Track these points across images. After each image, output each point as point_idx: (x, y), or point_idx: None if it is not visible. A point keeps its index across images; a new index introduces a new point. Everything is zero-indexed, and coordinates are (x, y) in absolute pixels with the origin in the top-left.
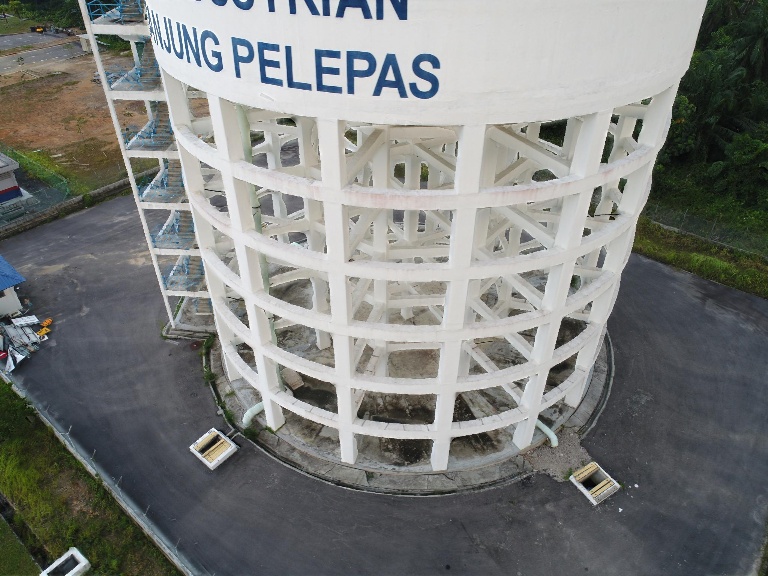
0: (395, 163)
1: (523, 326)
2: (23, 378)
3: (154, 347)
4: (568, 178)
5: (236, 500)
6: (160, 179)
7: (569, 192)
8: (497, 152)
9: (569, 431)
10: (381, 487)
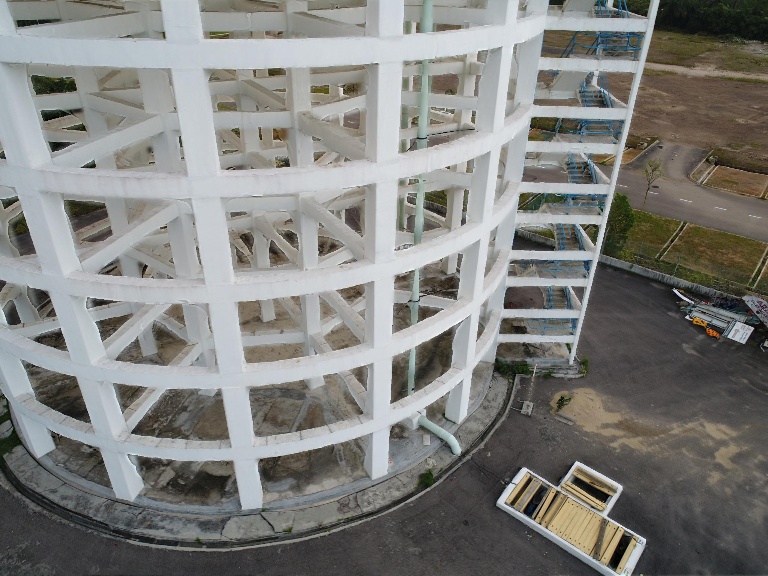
0: None
1: None
2: (656, 287)
3: None
4: None
5: None
6: (601, 182)
7: None
8: None
9: None
10: None
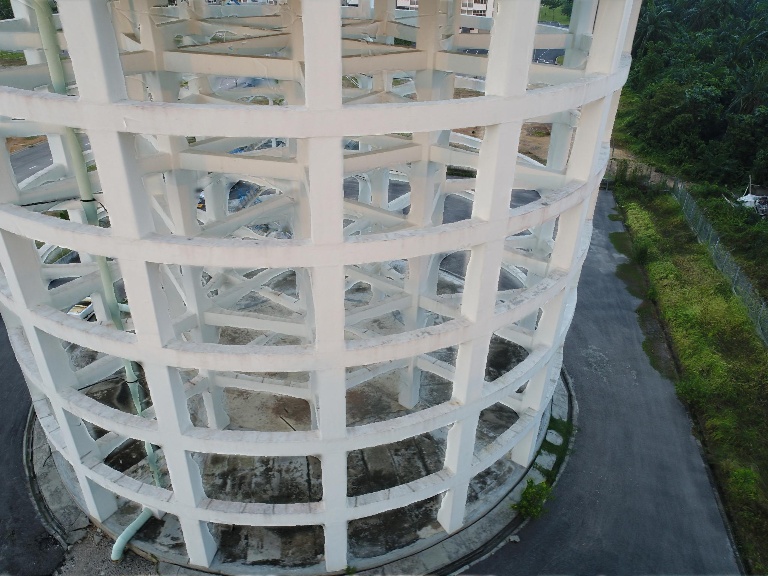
0: None
1: None
2: None
3: None
4: None
5: None
6: None
7: None
8: (160, 96)
9: (151, 572)
10: None
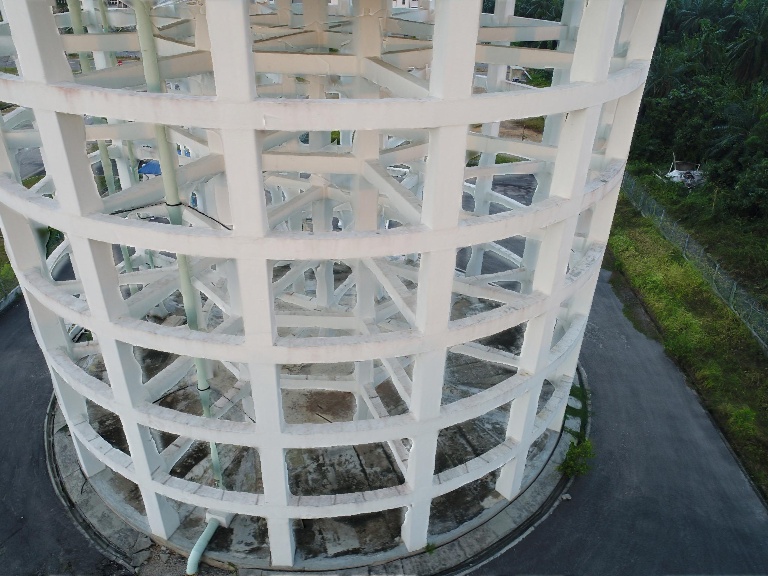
0: (487, 199)
1: (62, 311)
2: None
3: (173, 255)
4: (21, 77)
5: (11, 367)
6: None
7: (16, 99)
8: None
9: None
10: (55, 444)
